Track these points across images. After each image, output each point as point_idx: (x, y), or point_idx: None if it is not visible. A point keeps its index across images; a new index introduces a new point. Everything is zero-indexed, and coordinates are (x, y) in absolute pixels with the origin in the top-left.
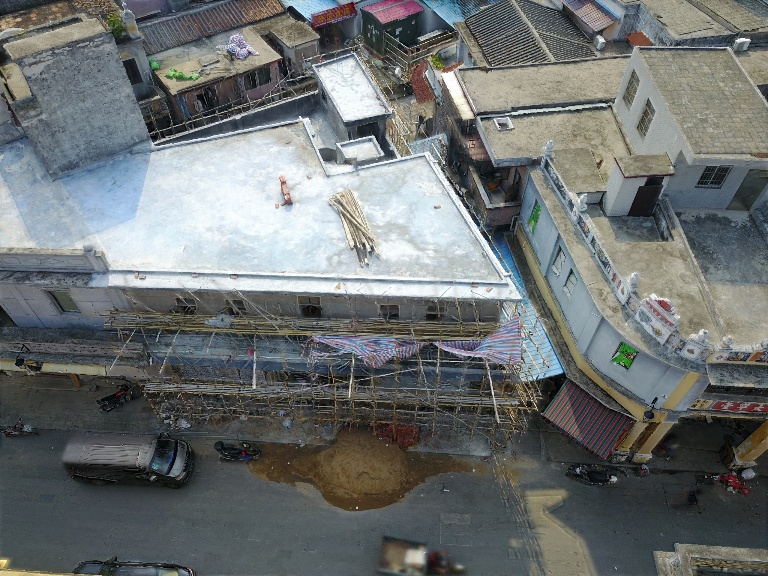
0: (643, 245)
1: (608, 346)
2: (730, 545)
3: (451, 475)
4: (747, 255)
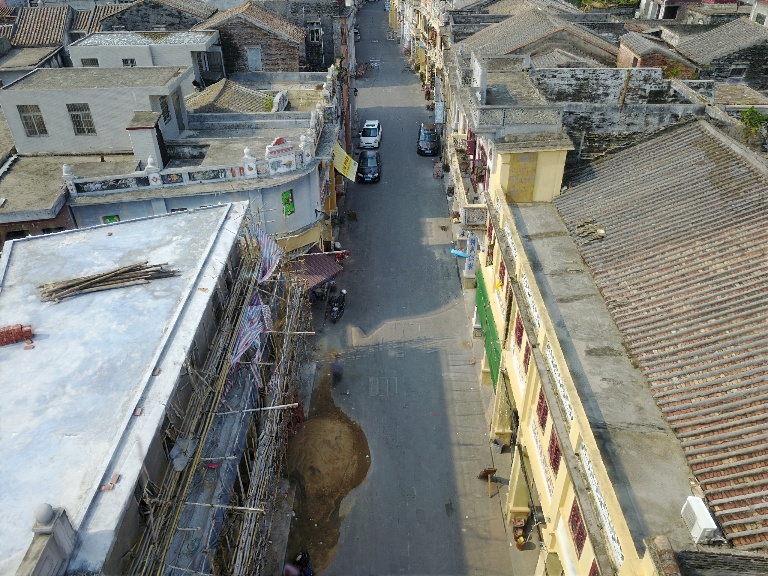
0: (210, 154)
1: (277, 209)
2: (383, 263)
3: (333, 389)
4: (227, 135)
